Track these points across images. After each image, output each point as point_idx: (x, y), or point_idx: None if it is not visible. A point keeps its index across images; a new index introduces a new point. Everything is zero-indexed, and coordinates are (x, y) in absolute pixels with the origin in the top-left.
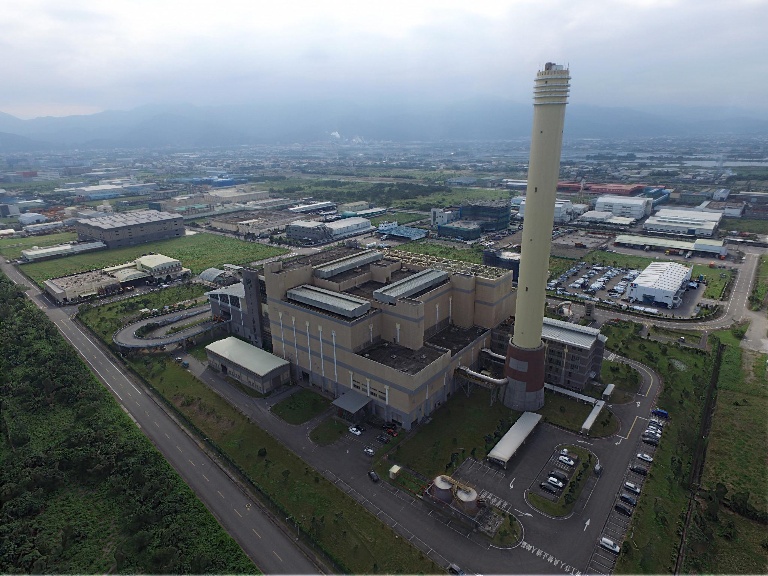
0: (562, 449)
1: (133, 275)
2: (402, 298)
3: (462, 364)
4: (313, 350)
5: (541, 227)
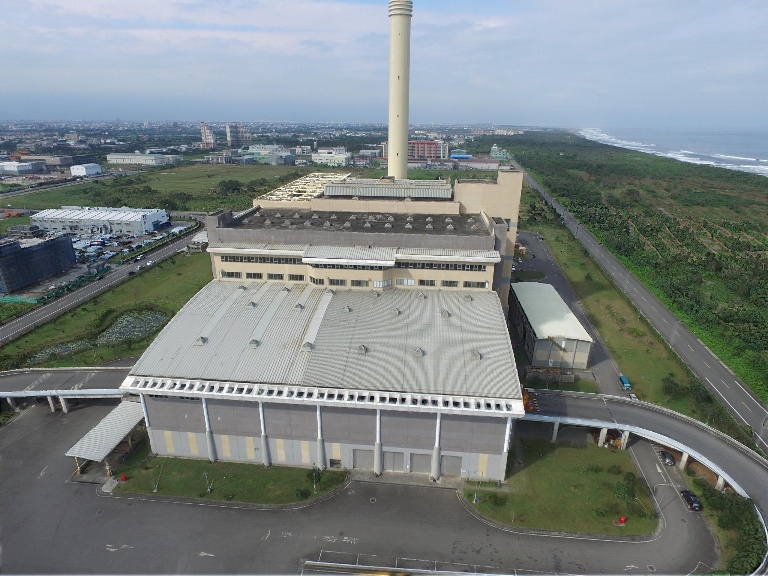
0: None
1: None
2: None
3: None
4: None
5: None
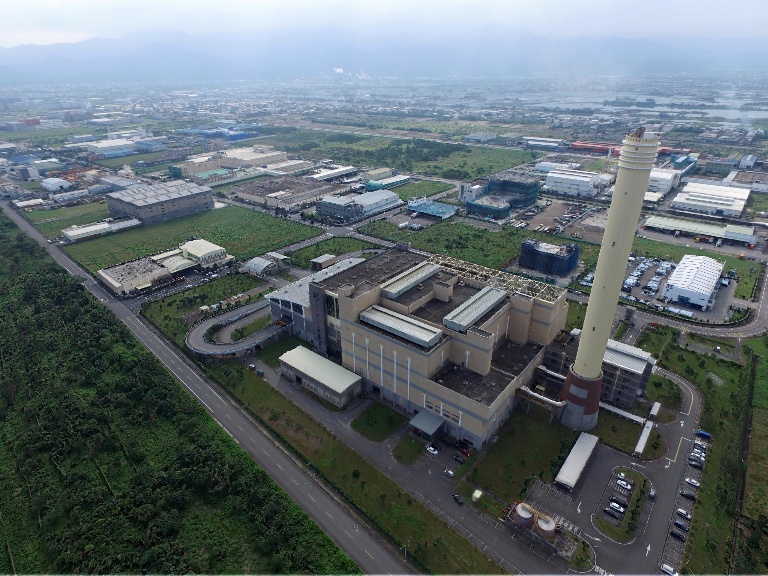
0: (619, 473)
1: (182, 265)
2: (472, 328)
3: (521, 383)
4: (386, 370)
5: (615, 277)
